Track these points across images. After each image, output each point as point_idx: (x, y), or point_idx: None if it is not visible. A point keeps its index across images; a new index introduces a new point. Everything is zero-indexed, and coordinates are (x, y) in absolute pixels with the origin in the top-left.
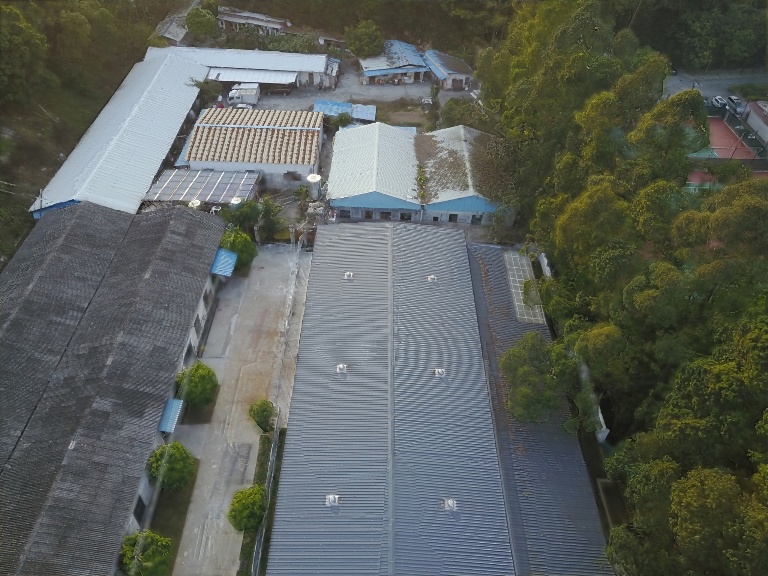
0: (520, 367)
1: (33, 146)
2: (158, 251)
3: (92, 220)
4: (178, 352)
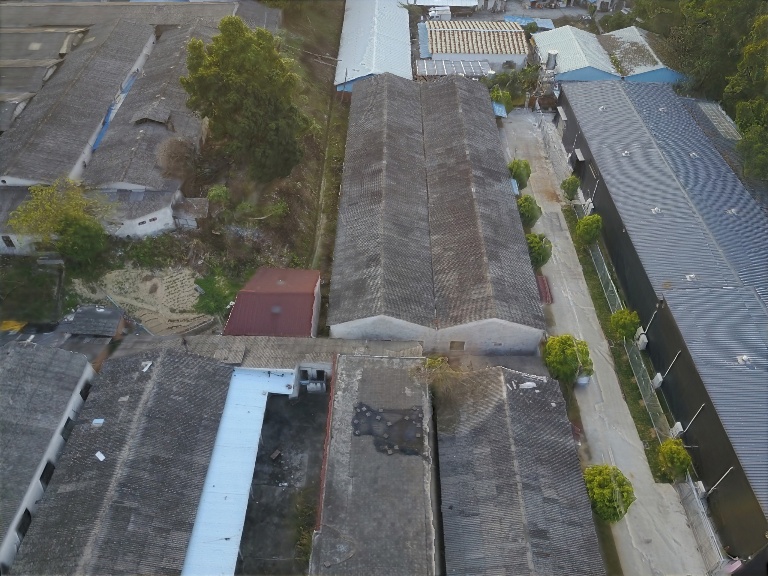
0: (755, 145)
1: (310, 46)
2: (459, 98)
3: (397, 84)
4: (501, 153)
